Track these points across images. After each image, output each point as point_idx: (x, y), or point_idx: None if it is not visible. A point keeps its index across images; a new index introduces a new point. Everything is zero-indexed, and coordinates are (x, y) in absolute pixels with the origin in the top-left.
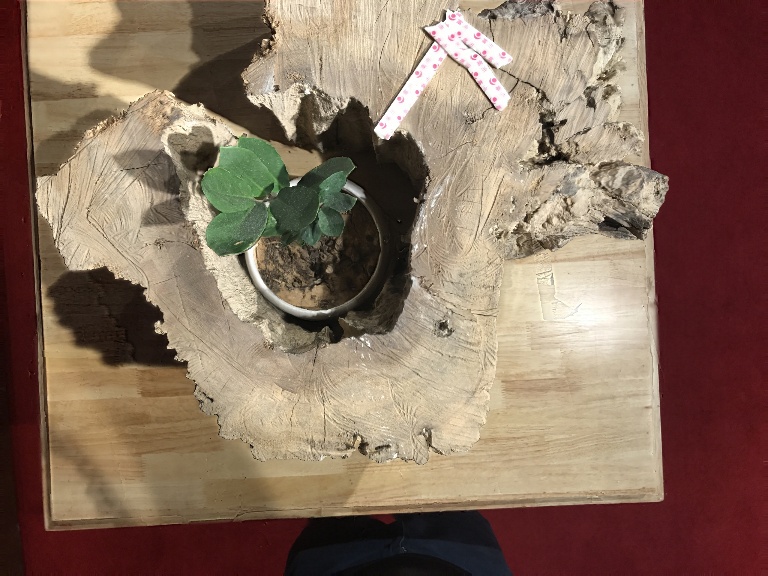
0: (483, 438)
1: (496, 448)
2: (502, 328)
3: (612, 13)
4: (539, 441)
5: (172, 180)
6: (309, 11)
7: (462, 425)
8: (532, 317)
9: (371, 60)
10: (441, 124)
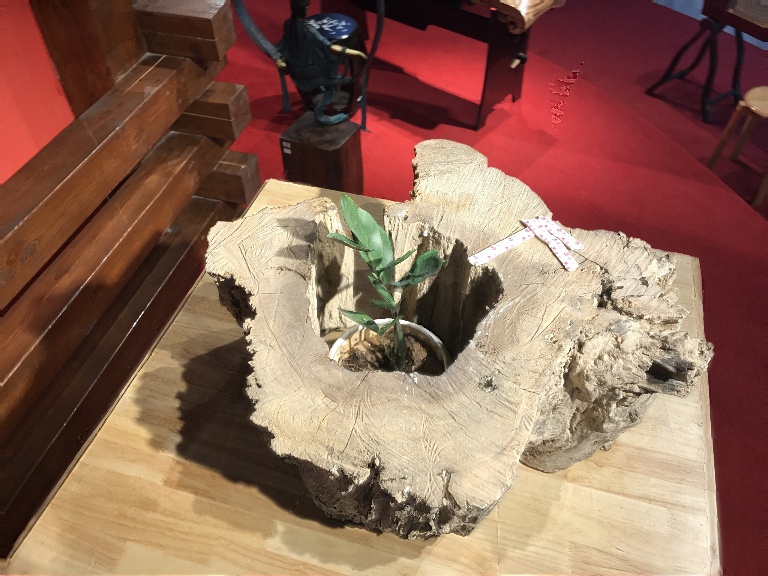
0: None
1: None
2: (542, 539)
3: (667, 258)
4: None
5: (311, 235)
6: (443, 194)
7: (484, 478)
8: (577, 538)
9: (478, 226)
10: (521, 269)
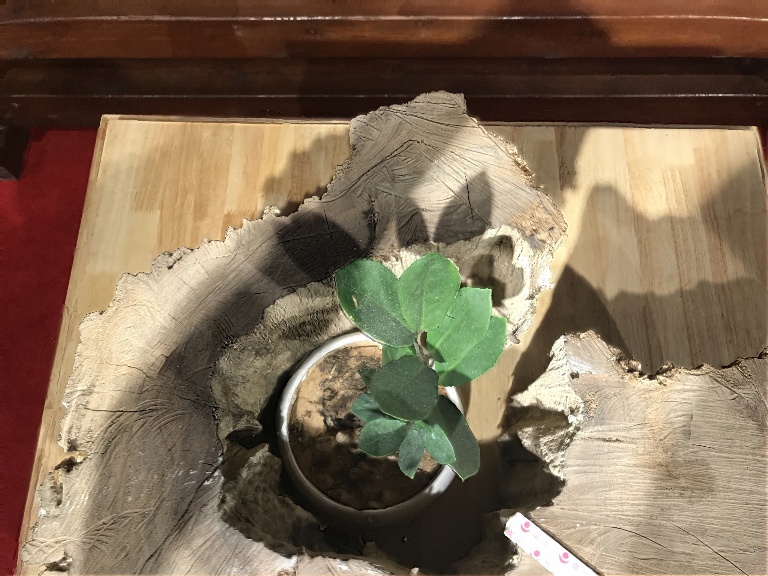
0: None
1: None
2: None
3: None
4: None
5: (452, 234)
6: (684, 428)
7: None
8: None
9: (621, 515)
10: None
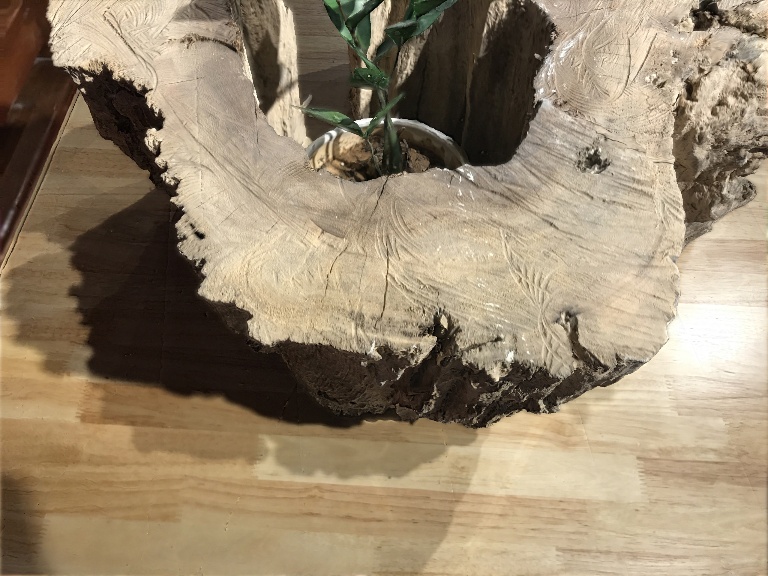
0: (614, 550)
1: (639, 571)
2: (630, 380)
3: None
4: (713, 567)
5: None
6: None
7: (634, 311)
8: (673, 369)
9: None
10: None
